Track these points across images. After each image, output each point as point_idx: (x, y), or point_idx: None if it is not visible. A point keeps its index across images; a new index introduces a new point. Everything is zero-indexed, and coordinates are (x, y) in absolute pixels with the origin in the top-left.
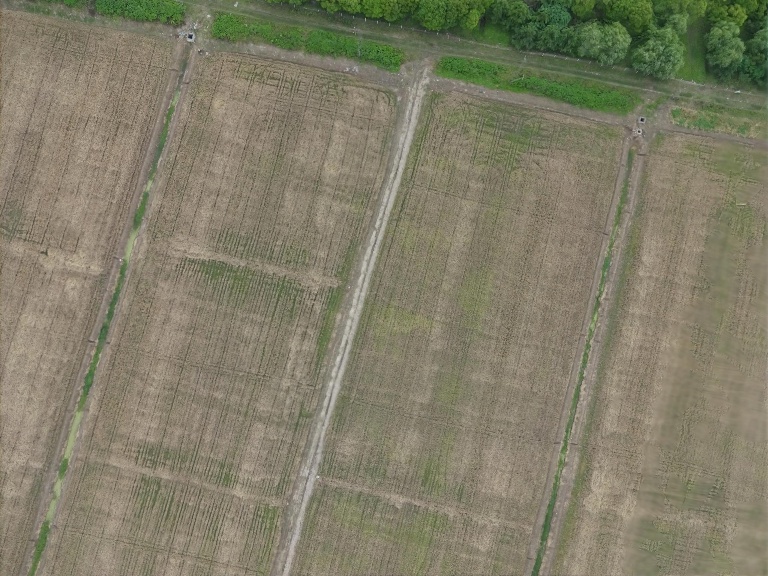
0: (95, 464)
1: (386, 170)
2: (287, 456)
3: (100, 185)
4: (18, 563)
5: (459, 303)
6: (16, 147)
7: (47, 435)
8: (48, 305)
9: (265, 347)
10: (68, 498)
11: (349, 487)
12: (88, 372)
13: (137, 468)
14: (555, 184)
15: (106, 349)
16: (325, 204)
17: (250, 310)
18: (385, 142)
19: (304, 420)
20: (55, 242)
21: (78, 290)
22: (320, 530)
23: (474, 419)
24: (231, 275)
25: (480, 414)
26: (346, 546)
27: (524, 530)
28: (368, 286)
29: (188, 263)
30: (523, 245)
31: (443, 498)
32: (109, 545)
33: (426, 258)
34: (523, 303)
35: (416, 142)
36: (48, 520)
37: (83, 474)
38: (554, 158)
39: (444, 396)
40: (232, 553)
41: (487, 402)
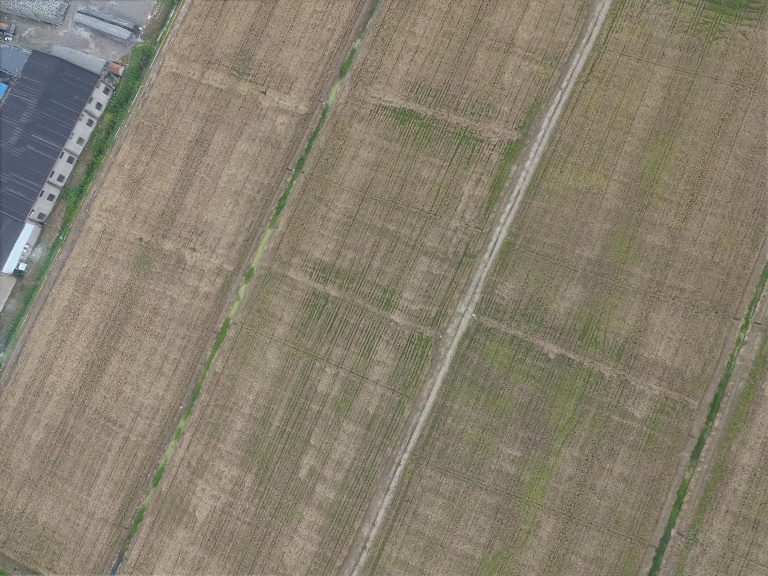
0: (276, 274)
1: (579, 36)
2: (447, 291)
3: (317, 40)
4: (201, 349)
5: (640, 165)
6: (256, 7)
7: (241, 244)
8: (260, 135)
9: (440, 188)
10: (249, 300)
11: (503, 329)
12: (282, 196)
13: (310, 282)
14: (762, 55)
15: (300, 177)
16: (514, 64)
17: (431, 154)
18: (581, 10)
19: (467, 260)
20: (274, 84)
21: (286, 125)
22: (469, 366)
23: (644, 281)
24: (418, 122)
25: (651, 277)
26: (493, 386)
27: (688, 404)
28: (547, 142)
29: (381, 109)
30: (718, 113)
31: (600, 355)
32: (276, 346)
33: (610, 119)
34: (712, 171)
35: (613, 11)
36: (230, 318)
37: (265, 281)
38: (763, 29)
39: (613, 254)
40: (383, 373)
41: (660, 265)
